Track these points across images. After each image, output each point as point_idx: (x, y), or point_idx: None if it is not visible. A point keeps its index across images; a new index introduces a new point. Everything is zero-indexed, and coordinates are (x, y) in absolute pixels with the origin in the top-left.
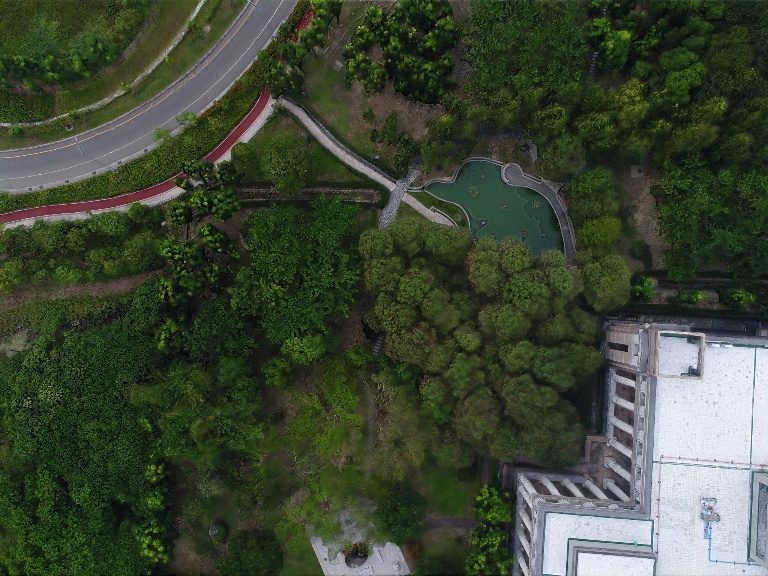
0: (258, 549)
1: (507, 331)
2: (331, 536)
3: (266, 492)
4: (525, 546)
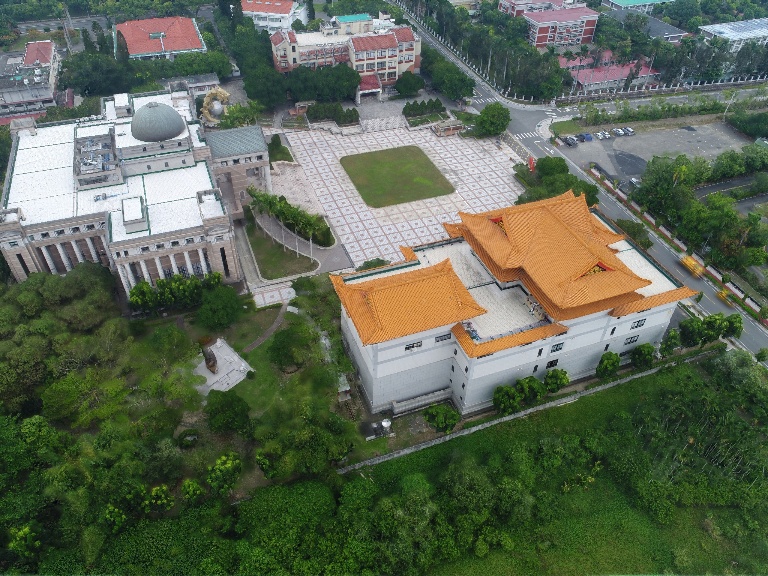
0: (209, 400)
1: (13, 313)
2: (187, 363)
3: (160, 408)
4: (158, 268)
